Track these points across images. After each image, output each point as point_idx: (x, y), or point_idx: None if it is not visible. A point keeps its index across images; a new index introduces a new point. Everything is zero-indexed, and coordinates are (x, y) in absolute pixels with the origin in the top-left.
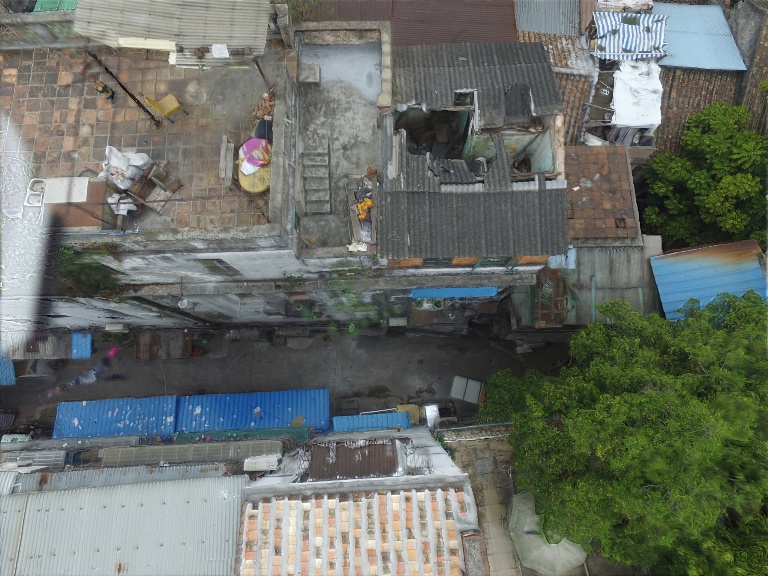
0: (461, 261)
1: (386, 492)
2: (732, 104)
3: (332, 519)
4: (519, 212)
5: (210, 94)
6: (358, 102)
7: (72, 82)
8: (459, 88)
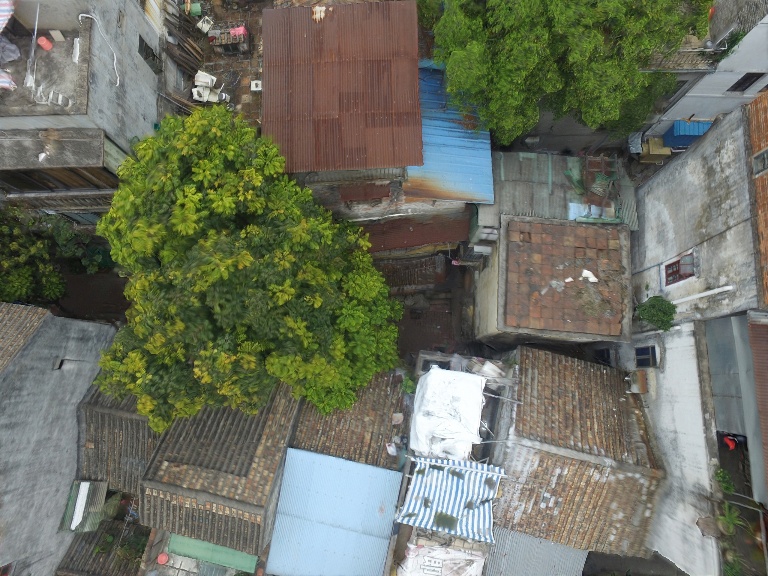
0: None
1: None
2: (301, 415)
3: None
4: None
5: None
6: None
7: None
8: None
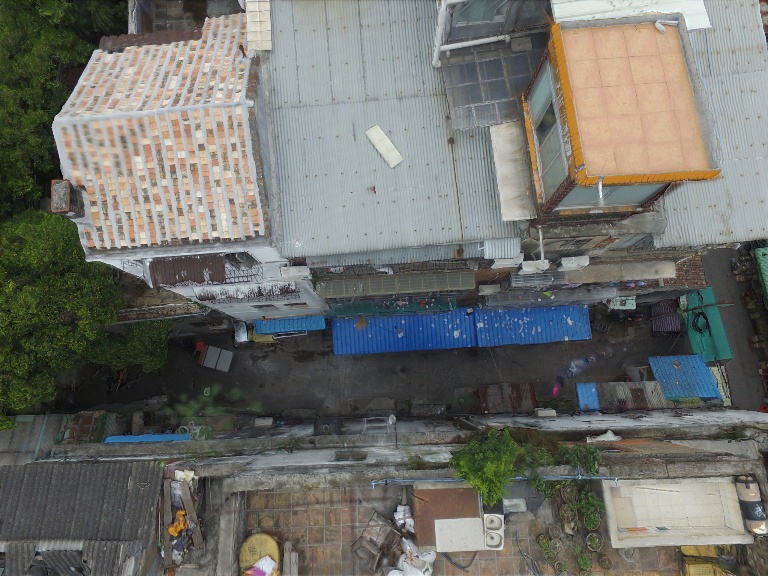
0: None
1: (153, 246)
2: None
3: (193, 225)
4: (8, 515)
5: None
6: None
7: None
8: None
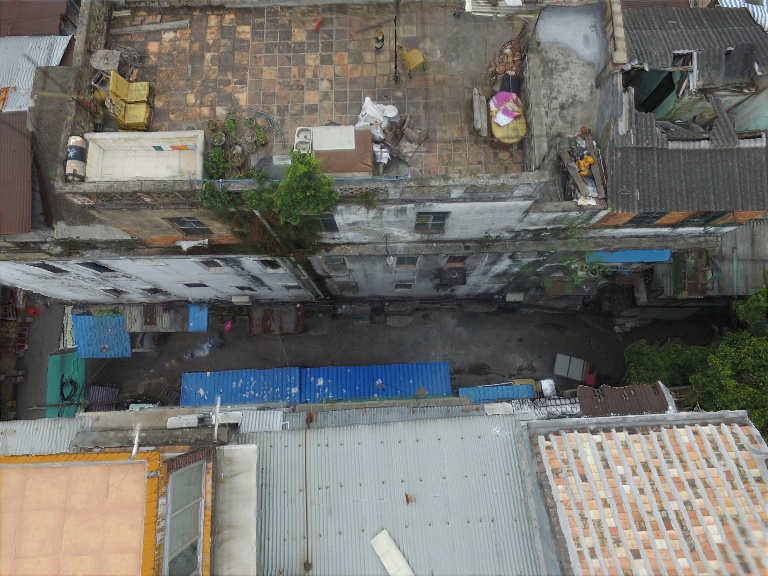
0: (665, 220)
1: (670, 426)
2: None
3: (626, 450)
4: (746, 168)
5: (444, 51)
6: (576, 62)
7: (306, 39)
8: (677, 49)
